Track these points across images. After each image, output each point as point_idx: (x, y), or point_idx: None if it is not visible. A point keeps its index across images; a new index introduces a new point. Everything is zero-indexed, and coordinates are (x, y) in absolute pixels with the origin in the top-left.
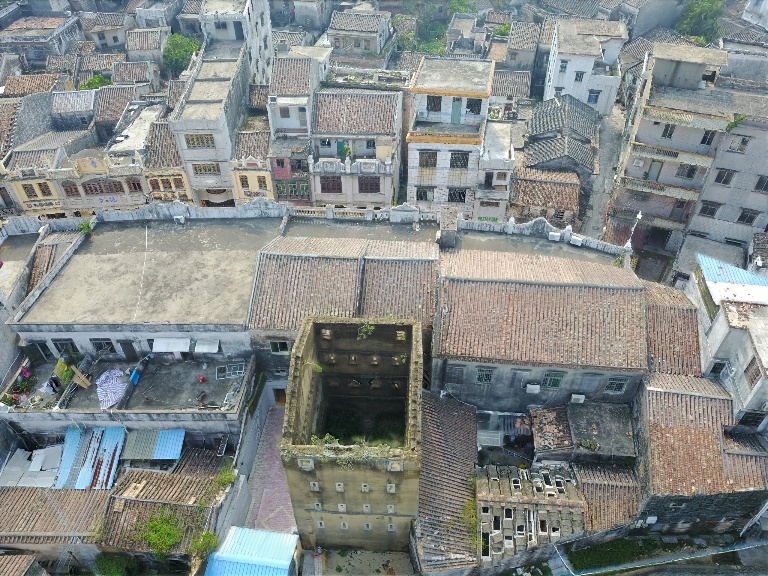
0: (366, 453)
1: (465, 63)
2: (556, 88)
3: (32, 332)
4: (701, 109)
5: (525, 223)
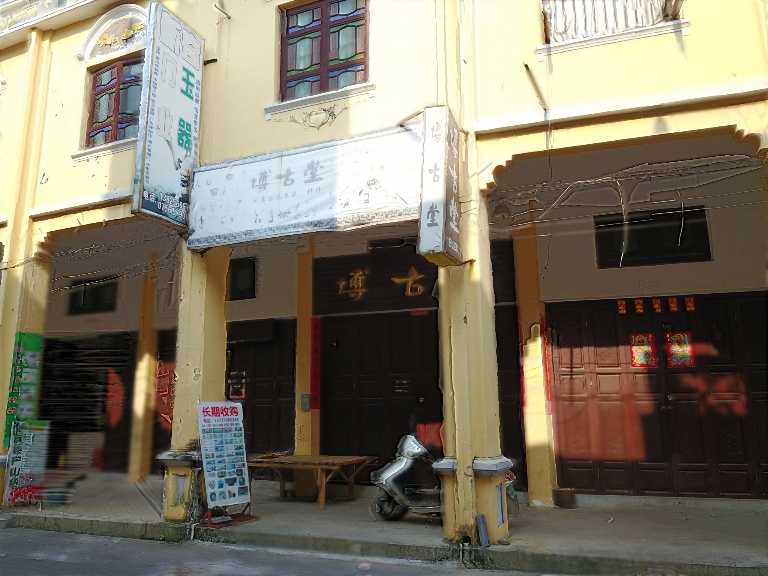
0: None
1: None
2: None
3: (715, 172)
4: None
5: None
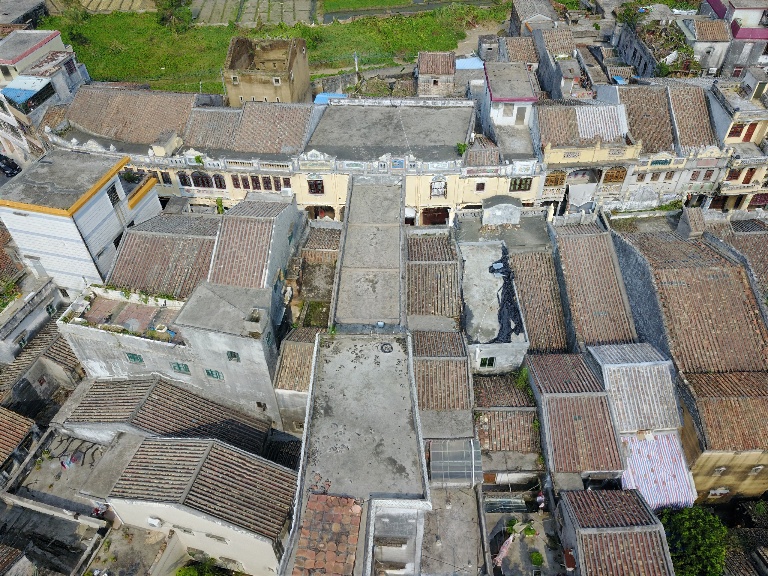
0: (270, 38)
1: (26, 199)
2: None
3: None
4: None
5: (103, 148)
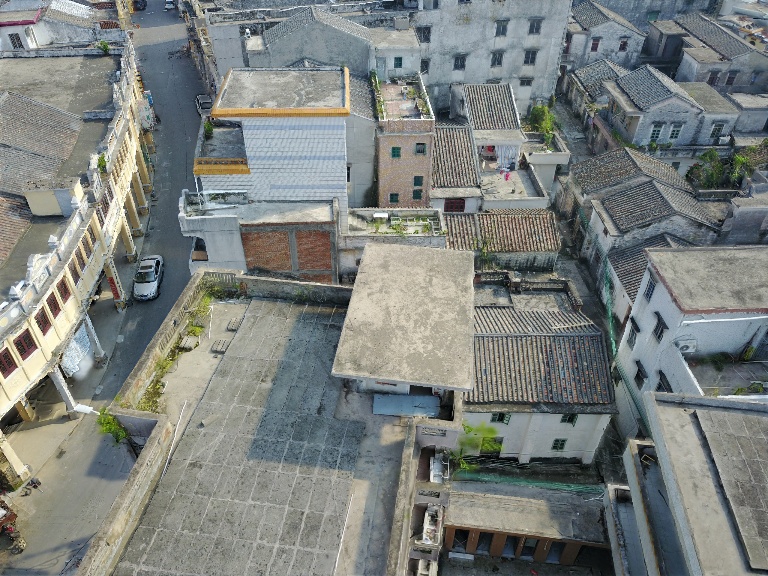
0: None
1: (334, 93)
2: (632, 320)
3: None
4: (230, 381)
5: (48, 254)
